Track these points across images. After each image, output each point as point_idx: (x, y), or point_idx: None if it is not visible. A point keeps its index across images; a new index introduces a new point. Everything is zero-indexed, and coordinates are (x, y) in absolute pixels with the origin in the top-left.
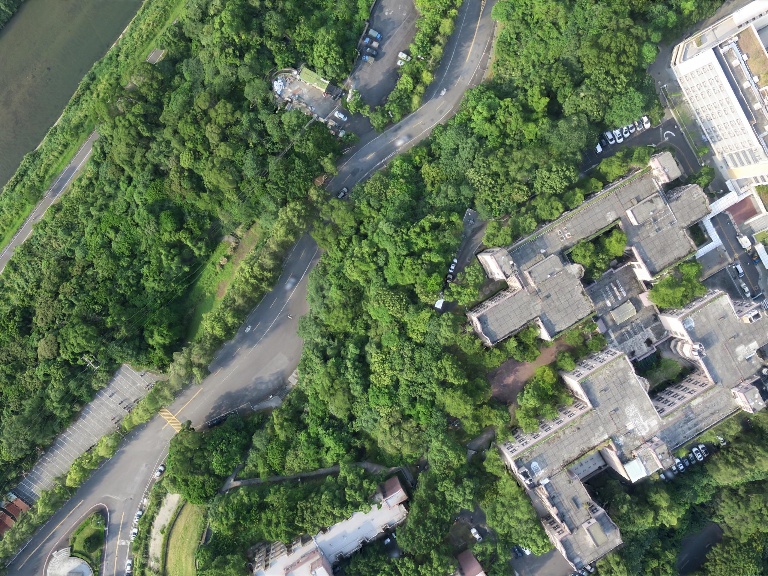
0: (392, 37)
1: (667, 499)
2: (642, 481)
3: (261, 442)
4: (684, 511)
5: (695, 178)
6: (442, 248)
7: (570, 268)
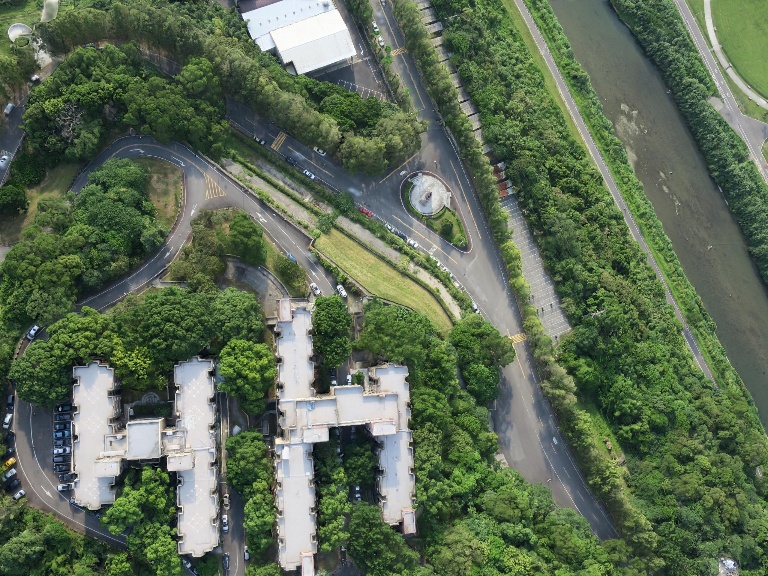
0: None
1: None
2: None
3: (484, 415)
4: None
5: None
6: None
7: None
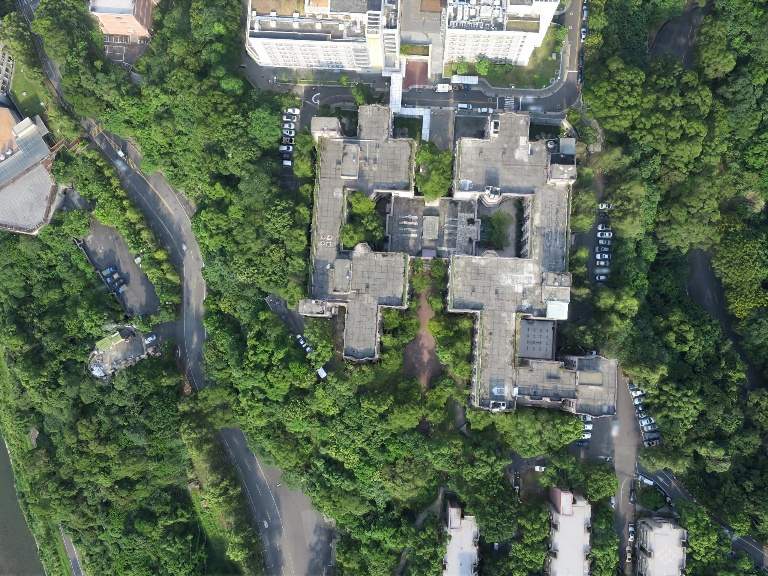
0: (120, 259)
1: (608, 296)
2: (587, 302)
3: None
4: (644, 280)
5: None
6: (278, 342)
7: (357, 253)
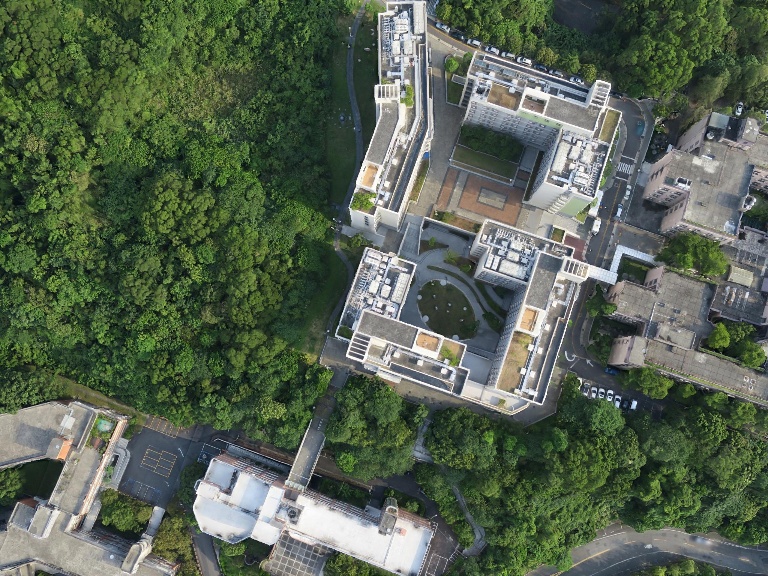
0: None
1: None
2: None
3: None
4: None
5: None
6: None
7: None
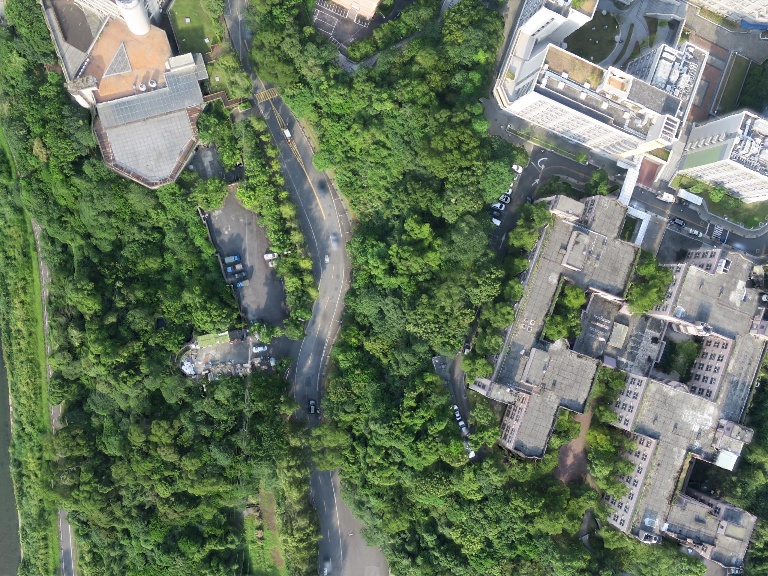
0: (247, 248)
1: (764, 454)
2: None
3: None
4: None
5: (593, 187)
6: (439, 411)
7: (554, 346)
